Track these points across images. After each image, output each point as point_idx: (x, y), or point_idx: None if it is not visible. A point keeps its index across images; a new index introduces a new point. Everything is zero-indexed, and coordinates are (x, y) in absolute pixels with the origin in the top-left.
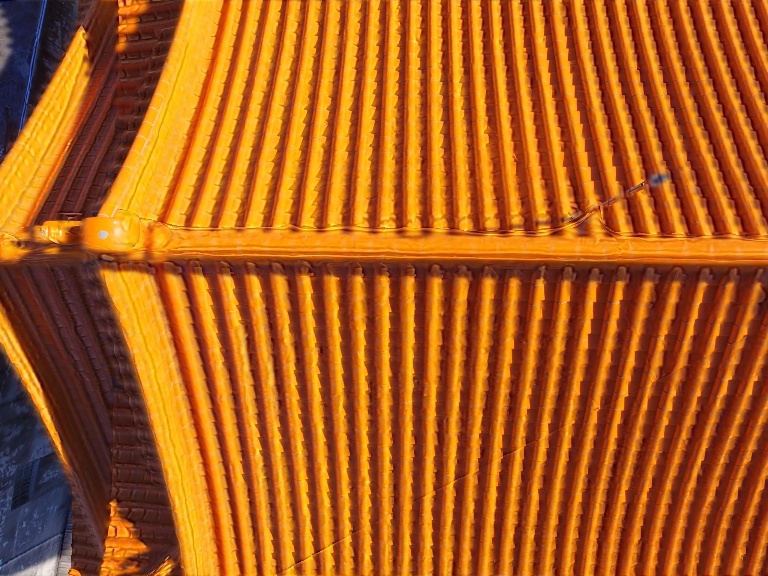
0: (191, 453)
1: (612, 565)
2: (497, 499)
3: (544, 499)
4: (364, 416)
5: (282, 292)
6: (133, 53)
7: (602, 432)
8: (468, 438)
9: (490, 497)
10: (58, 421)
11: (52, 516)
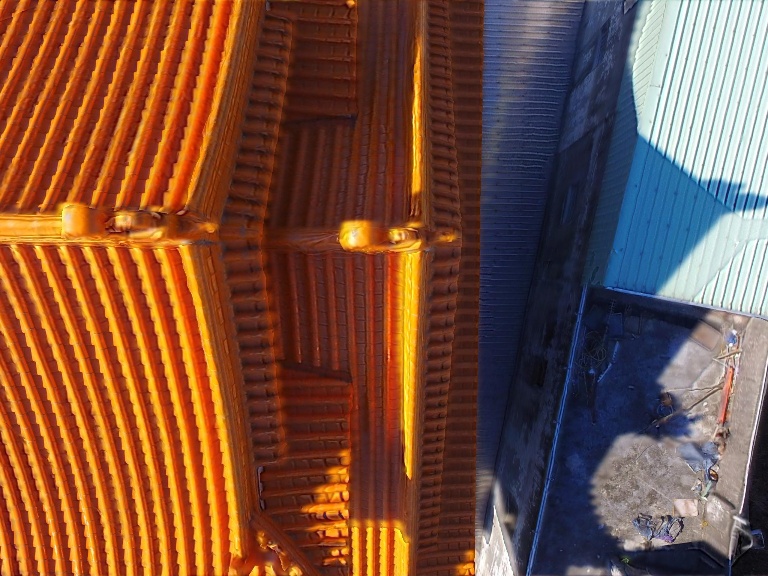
0: None
1: None
2: None
3: None
4: (50, 82)
5: (76, 191)
6: (333, 446)
7: None
8: None
9: None
10: None
11: None
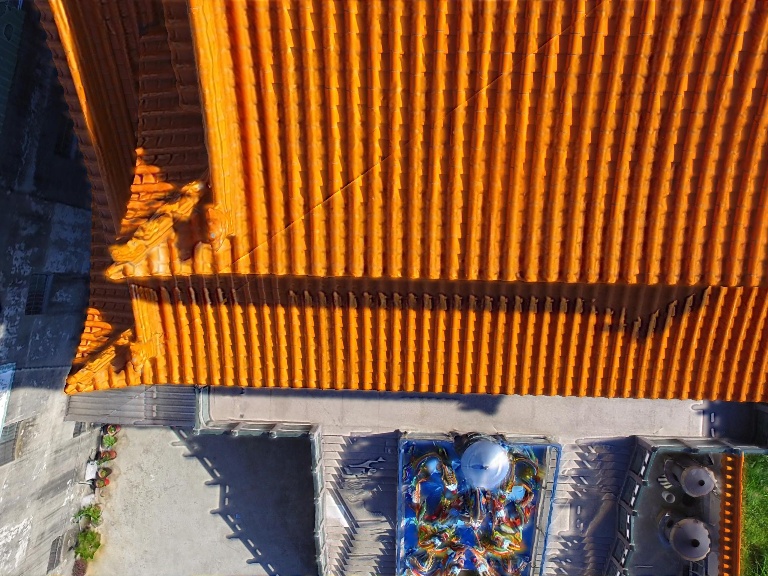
0: (222, 52)
1: (644, 195)
2: (530, 110)
3: (577, 109)
4: None
5: None
6: None
7: (639, 11)
8: (503, 23)
9: (523, 106)
10: (84, 75)
11: (64, 343)
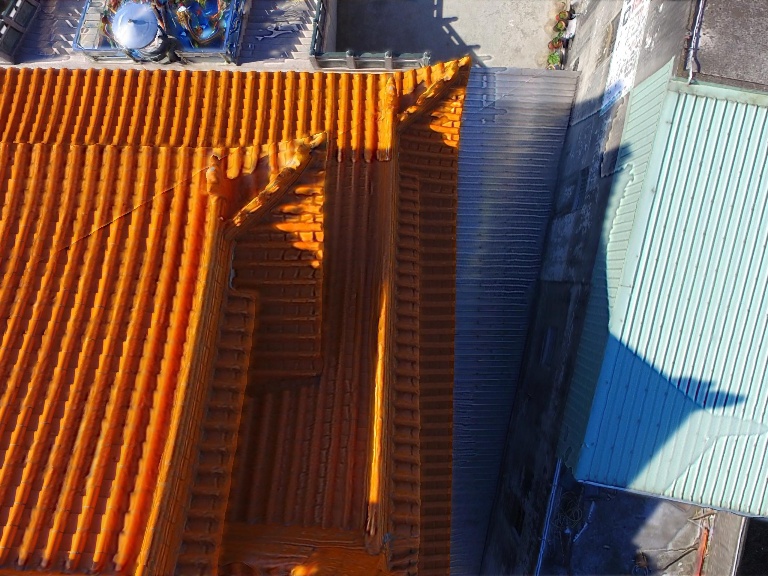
0: None
1: None
2: None
3: None
4: (13, 382)
5: (32, 529)
6: None
7: None
8: None
9: None
10: None
11: None
